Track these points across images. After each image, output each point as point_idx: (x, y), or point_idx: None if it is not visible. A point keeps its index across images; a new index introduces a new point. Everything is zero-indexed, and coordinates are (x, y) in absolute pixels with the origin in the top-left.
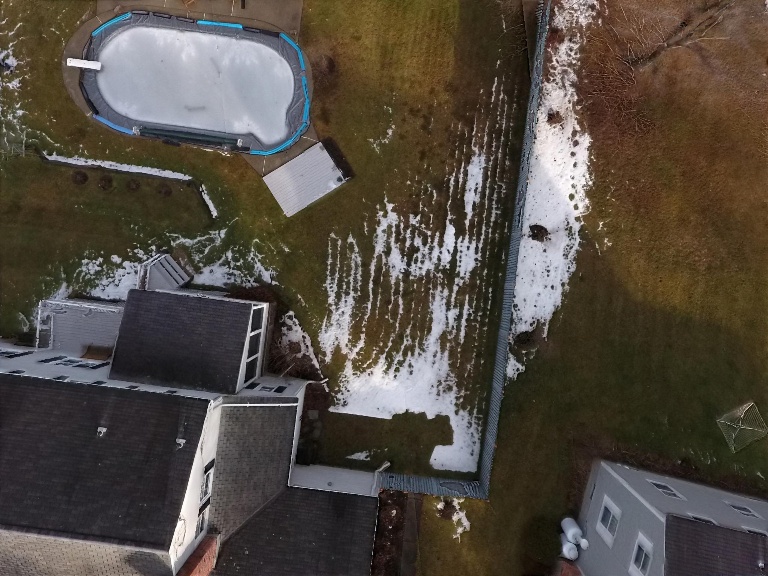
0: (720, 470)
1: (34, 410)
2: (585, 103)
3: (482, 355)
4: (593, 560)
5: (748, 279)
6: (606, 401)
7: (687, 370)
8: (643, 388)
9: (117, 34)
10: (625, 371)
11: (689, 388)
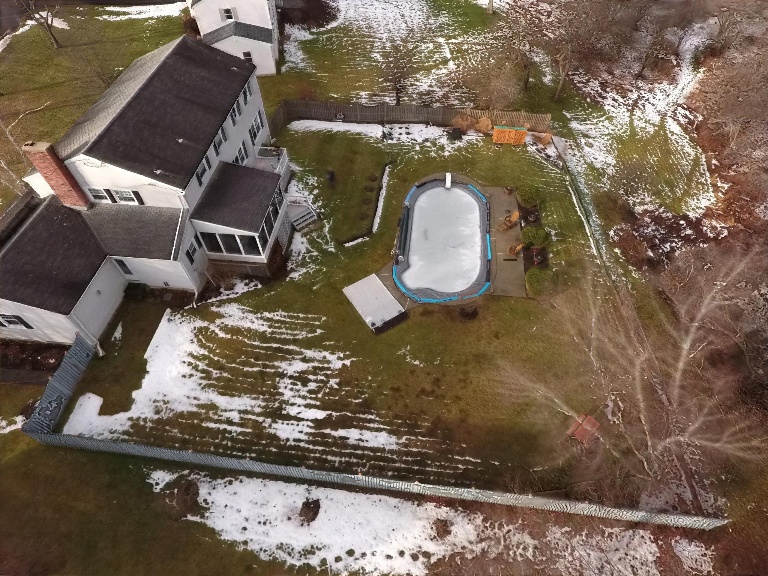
0: None
1: (204, 118)
2: (464, 569)
3: (184, 445)
4: None
5: None
6: None
7: None
8: None
9: (472, 196)
10: None
11: None
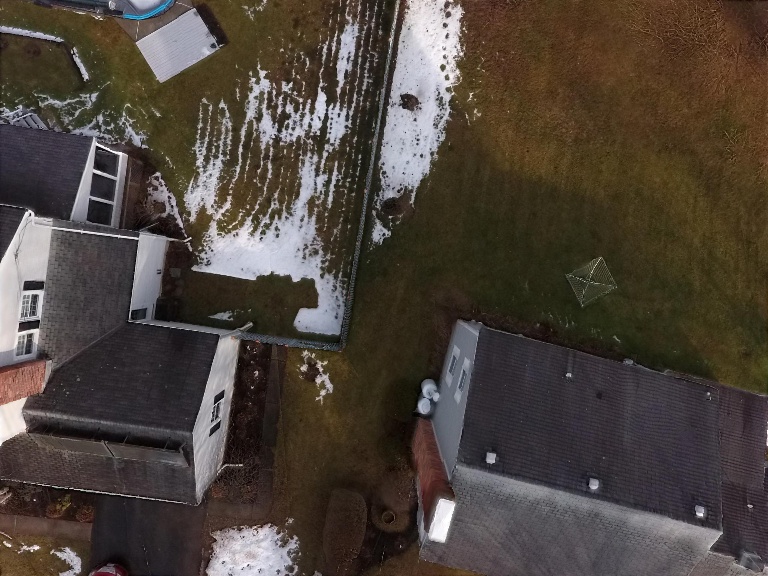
0: (577, 333)
1: None
2: None
3: (349, 220)
4: (441, 409)
5: (613, 151)
6: (468, 265)
7: (550, 237)
8: (506, 253)
9: None
10: (489, 237)
11: (551, 254)
